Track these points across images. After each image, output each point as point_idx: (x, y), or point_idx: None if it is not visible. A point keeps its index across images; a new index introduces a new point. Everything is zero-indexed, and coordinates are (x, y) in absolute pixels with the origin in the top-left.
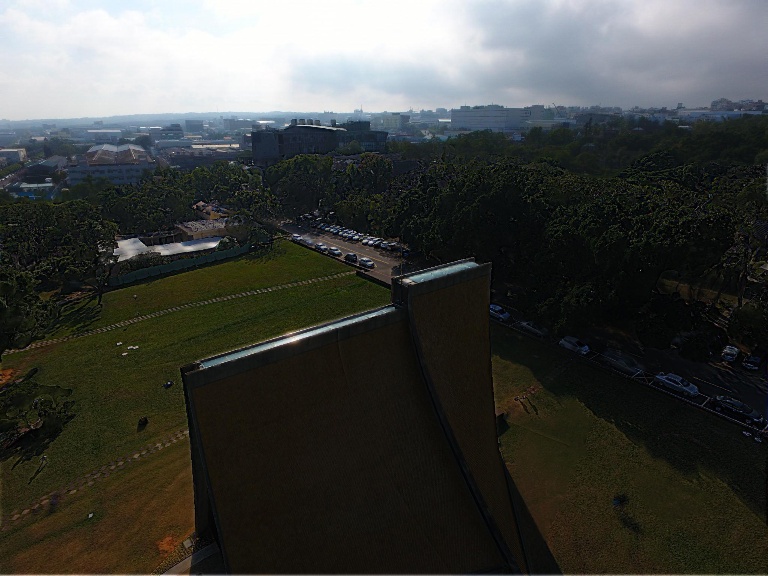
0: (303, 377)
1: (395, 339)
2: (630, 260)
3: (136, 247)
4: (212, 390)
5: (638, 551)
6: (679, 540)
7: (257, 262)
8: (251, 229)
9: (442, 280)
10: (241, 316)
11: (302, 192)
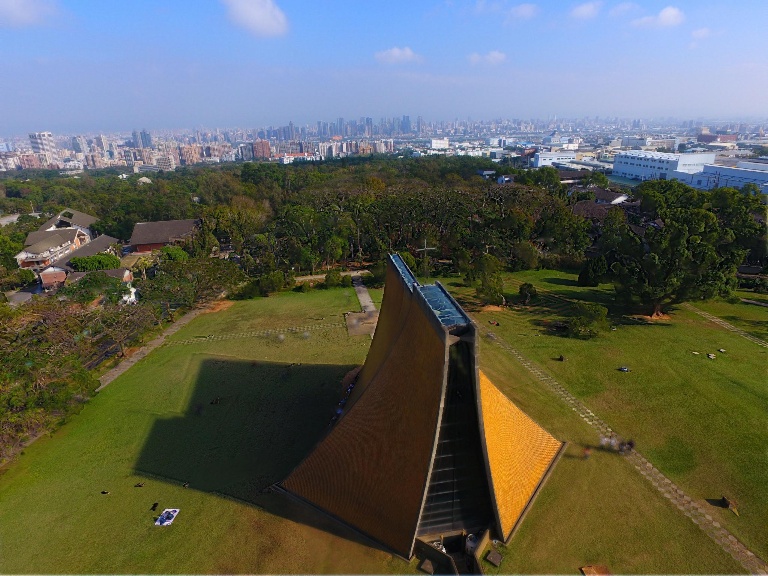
0: None
1: None
2: None
3: None
4: None
5: None
6: None
7: None
8: None
9: None
10: None
11: None
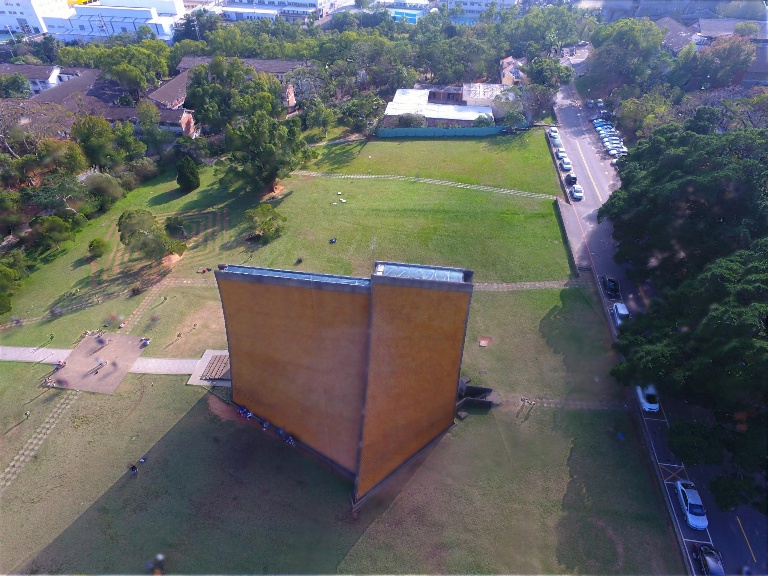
0: (284, 299)
1: (361, 304)
2: (725, 354)
3: (421, 100)
4: (229, 283)
5: (446, 550)
6: (485, 574)
7: (492, 150)
8: (510, 111)
9: (407, 281)
10: (422, 205)
11: (603, 73)
